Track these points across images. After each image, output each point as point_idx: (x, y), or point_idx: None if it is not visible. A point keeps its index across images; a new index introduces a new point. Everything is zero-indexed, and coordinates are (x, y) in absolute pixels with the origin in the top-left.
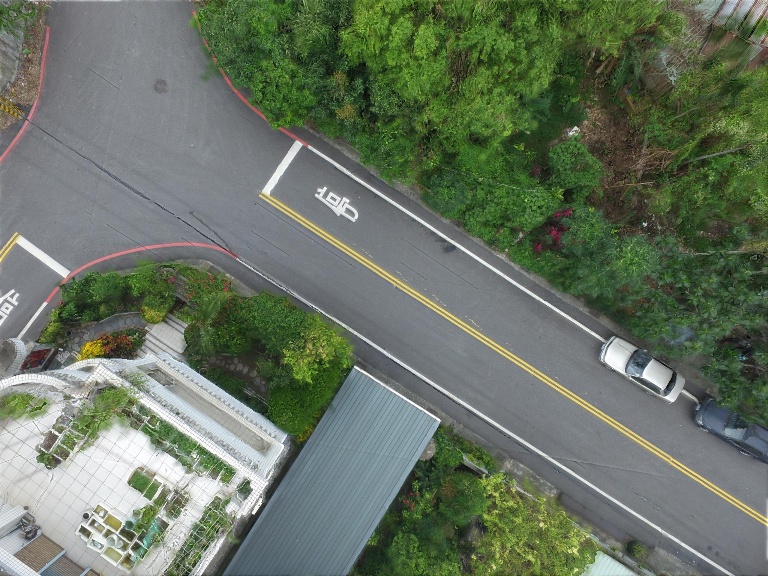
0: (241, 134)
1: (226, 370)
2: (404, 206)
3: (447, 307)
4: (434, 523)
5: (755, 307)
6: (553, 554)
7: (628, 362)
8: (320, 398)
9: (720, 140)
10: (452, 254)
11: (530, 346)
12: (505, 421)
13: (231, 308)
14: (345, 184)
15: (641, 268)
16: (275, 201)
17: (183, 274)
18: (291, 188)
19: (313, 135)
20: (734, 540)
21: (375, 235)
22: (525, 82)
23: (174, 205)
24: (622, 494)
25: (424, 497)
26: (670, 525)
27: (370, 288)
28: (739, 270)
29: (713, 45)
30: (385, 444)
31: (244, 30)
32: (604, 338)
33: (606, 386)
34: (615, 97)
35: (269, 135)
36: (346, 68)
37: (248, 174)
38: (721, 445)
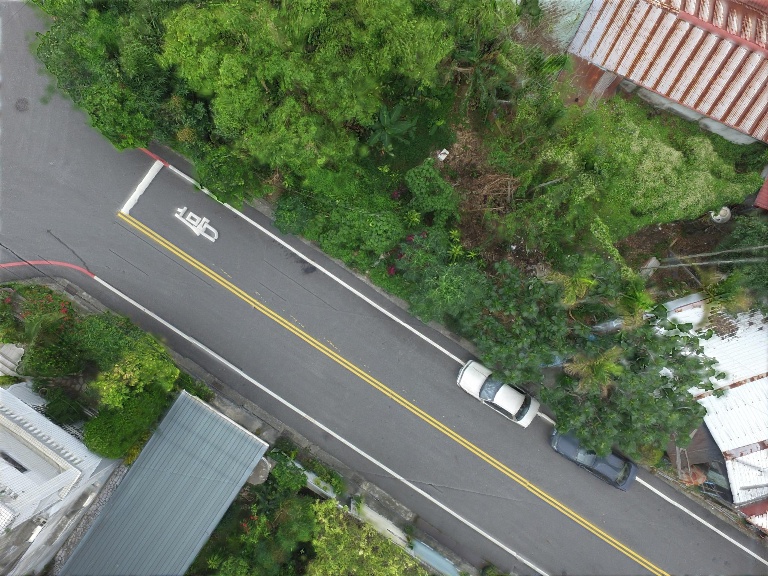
0: (102, 153)
1: (72, 390)
2: (265, 227)
3: (305, 328)
4: (267, 548)
5: (575, 337)
6: None
7: (482, 386)
8: (131, 423)
9: (556, 168)
10: (312, 275)
11: (388, 368)
12: (362, 443)
13: (67, 329)
14: (206, 204)
15: (455, 297)
16: (134, 220)
17: (22, 294)
18: (151, 207)
19: (175, 155)
20: (589, 566)
21: (235, 255)
22: (335, 111)
23: (32, 223)
24: (478, 518)
25: (262, 521)
26: (525, 550)
27: (228, 308)
28: (558, 300)
29: (569, 72)
30: (211, 469)
31: (70, 54)
32: (464, 361)
33: (464, 409)
34: (486, 120)
35: (130, 154)
36: (186, 91)
37: (107, 193)
38: (579, 470)
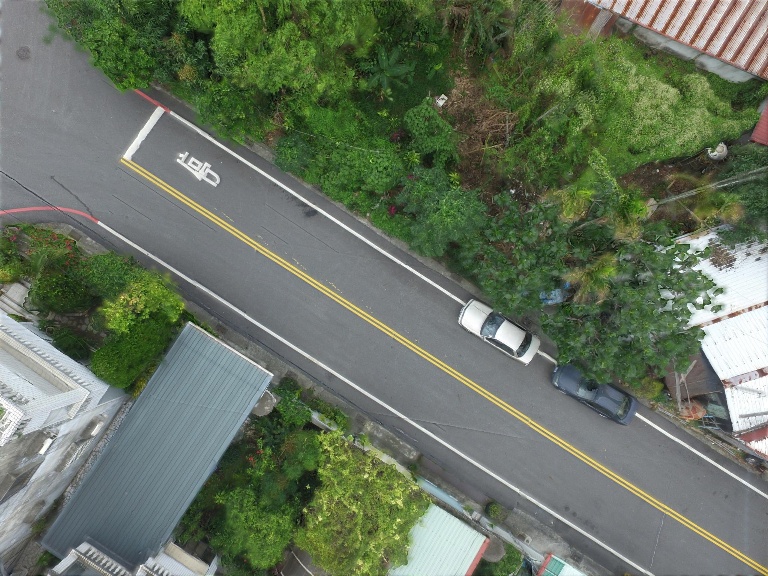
0: (104, 100)
1: (78, 330)
2: (266, 171)
3: (307, 271)
4: (274, 479)
5: (574, 260)
6: (377, 505)
7: (484, 324)
8: (138, 348)
9: (553, 99)
10: (314, 218)
11: (390, 309)
12: (365, 384)
13: (73, 266)
14: (207, 149)
15: (456, 220)
16: (136, 166)
17: (27, 233)
18: (153, 153)
19: (176, 101)
20: (592, 501)
21: (237, 200)
22: (334, 35)
23: (35, 169)
24: (481, 456)
25: (268, 454)
26: (528, 486)
27: (231, 252)
28: (557, 223)
29: (565, 11)
30: (217, 398)
31: None
32: (465, 302)
33: (466, 349)
34: (483, 66)
35: (132, 101)
36: (186, 29)
37: (109, 139)
38: (580, 407)
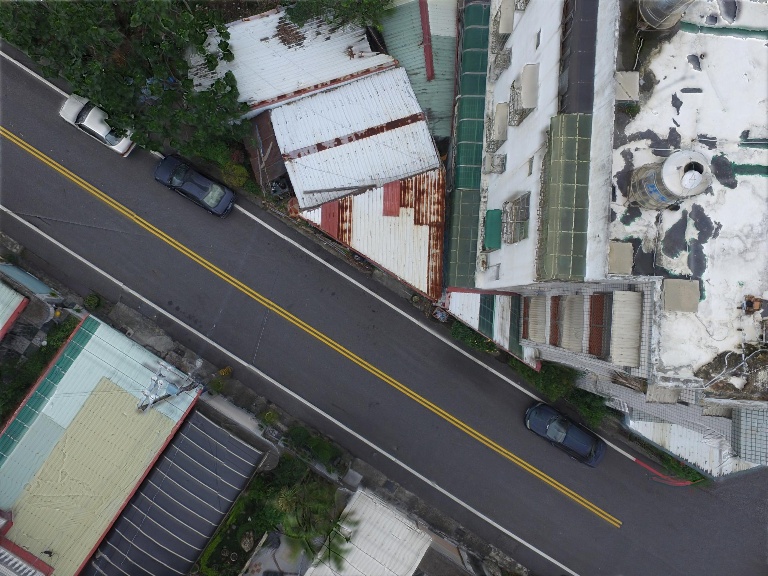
0: None
1: None
2: None
3: None
4: None
5: None
6: None
7: (80, 114)
8: None
9: None
10: None
11: None
12: None
13: None
14: None
15: None
16: None
17: None
18: None
19: None
20: (195, 295)
21: None
22: None
23: None
24: (86, 250)
25: None
26: (132, 280)
27: None
28: None
29: None
30: None
31: None
32: None
33: (73, 144)
34: None
35: None
36: None
37: None
38: (188, 204)
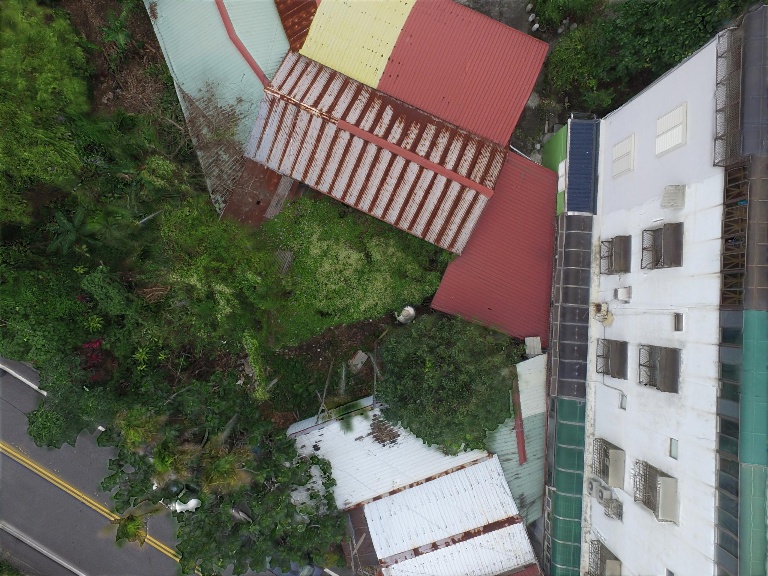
0: None
1: None
2: None
3: None
4: None
5: None
6: None
7: None
8: None
9: None
10: (2, 380)
11: (79, 472)
12: (52, 548)
13: None
14: None
15: (50, 433)
16: None
17: None
18: None
19: None
20: None
21: None
22: None
23: None
24: None
25: None
26: None
27: None
28: None
29: (247, 176)
30: None
31: None
32: None
33: (158, 511)
34: None
35: None
36: None
37: None
38: None
